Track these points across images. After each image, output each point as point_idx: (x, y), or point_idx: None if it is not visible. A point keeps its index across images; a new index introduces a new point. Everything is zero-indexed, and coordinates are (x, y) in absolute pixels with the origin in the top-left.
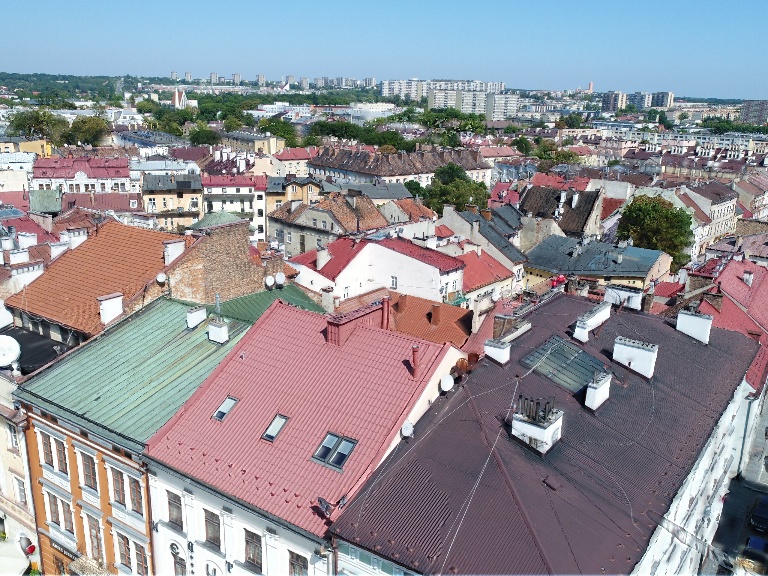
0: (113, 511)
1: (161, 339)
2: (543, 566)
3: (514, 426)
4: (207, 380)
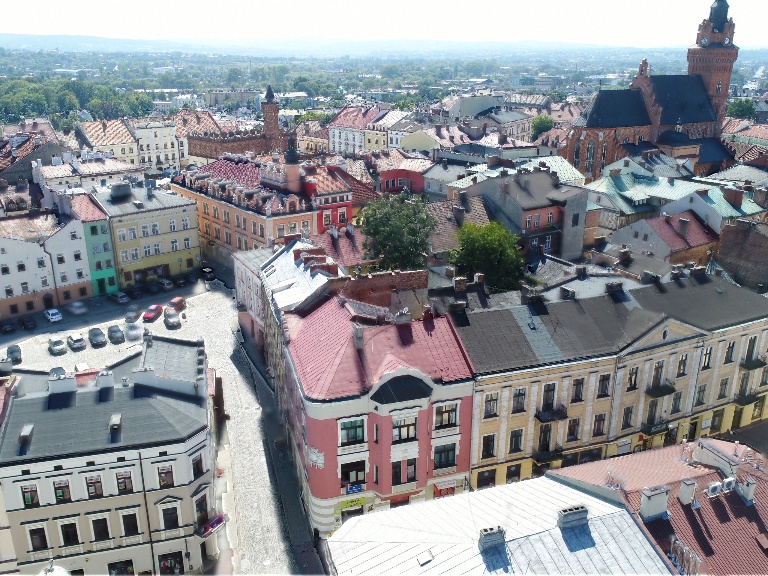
0: None
1: None
2: None
3: None
4: None
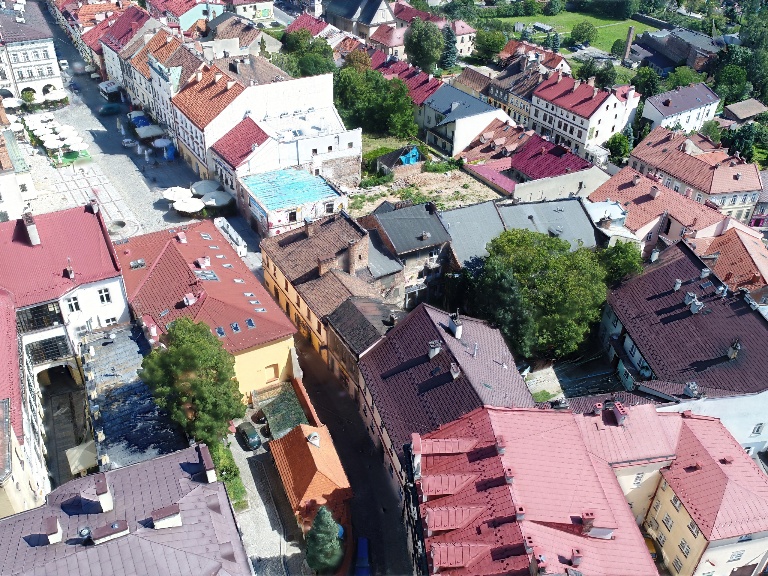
0: None
1: None
2: (41, 33)
3: (17, 20)
4: None
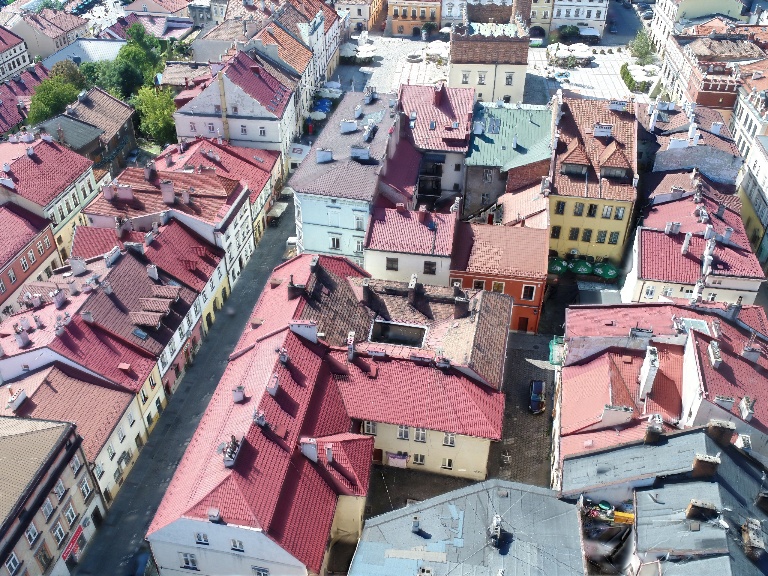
0: None
1: None
2: None
3: None
4: None
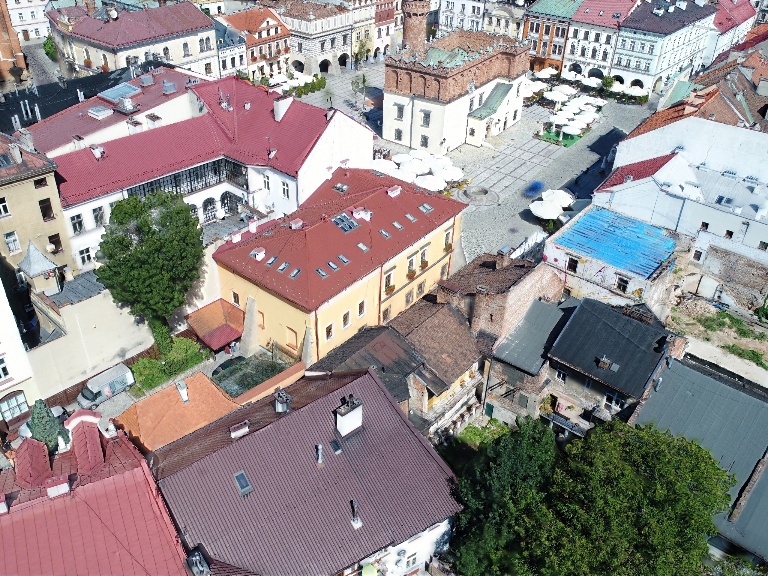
0: (554, 39)
1: (557, 0)
2: None
3: (654, 11)
4: (581, 6)
